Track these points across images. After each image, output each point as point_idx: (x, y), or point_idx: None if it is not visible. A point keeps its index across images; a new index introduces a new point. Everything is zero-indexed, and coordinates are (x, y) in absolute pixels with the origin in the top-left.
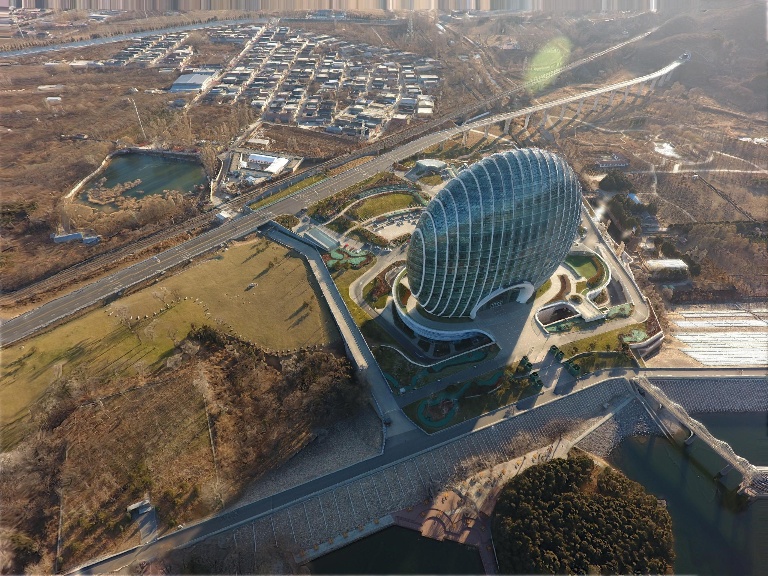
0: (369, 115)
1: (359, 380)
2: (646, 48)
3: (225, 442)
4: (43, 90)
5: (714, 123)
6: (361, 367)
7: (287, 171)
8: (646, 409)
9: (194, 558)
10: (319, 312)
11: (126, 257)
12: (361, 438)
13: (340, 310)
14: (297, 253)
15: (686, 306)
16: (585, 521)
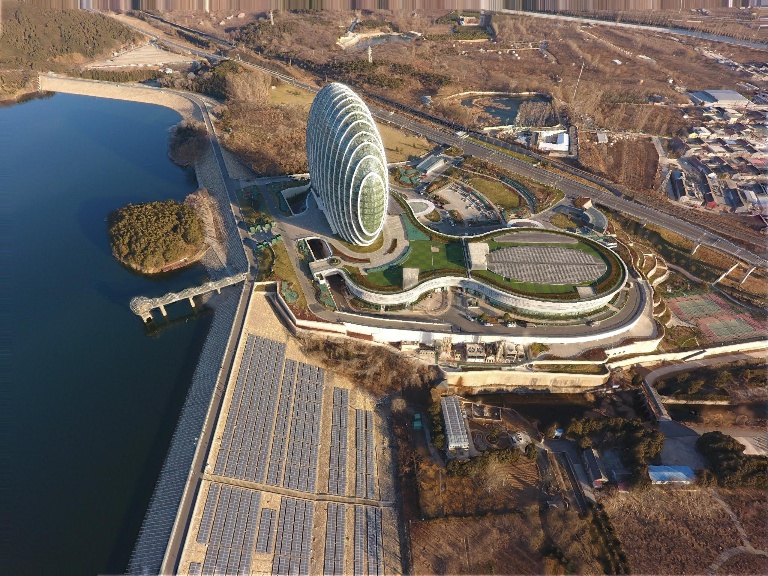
0: (747, 196)
1: None
2: None
3: None
4: (634, 57)
5: None
6: (293, 177)
7: (544, 151)
8: None
9: None
10: None
11: (409, 115)
12: None
13: None
14: None
15: (385, 431)
16: None
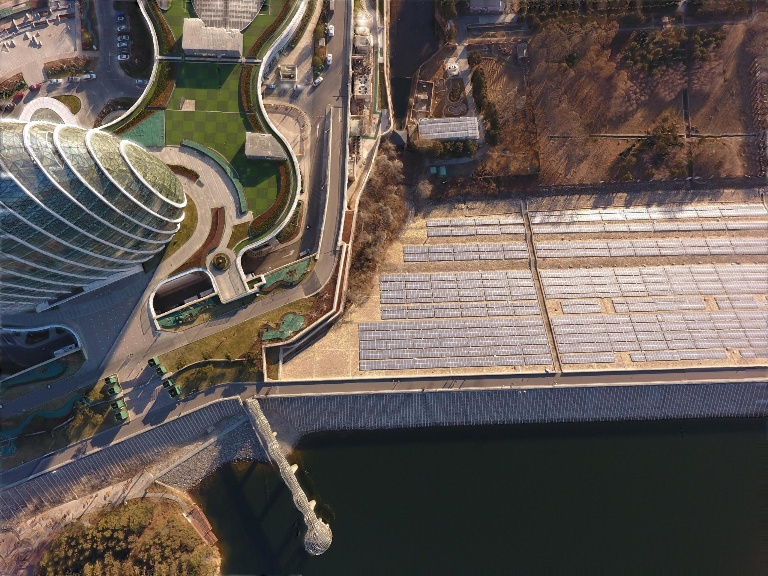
0: None
1: None
2: None
3: None
4: None
5: None
6: None
7: None
8: (256, 434)
9: None
10: None
11: None
12: None
13: None
14: None
15: (448, 207)
16: None
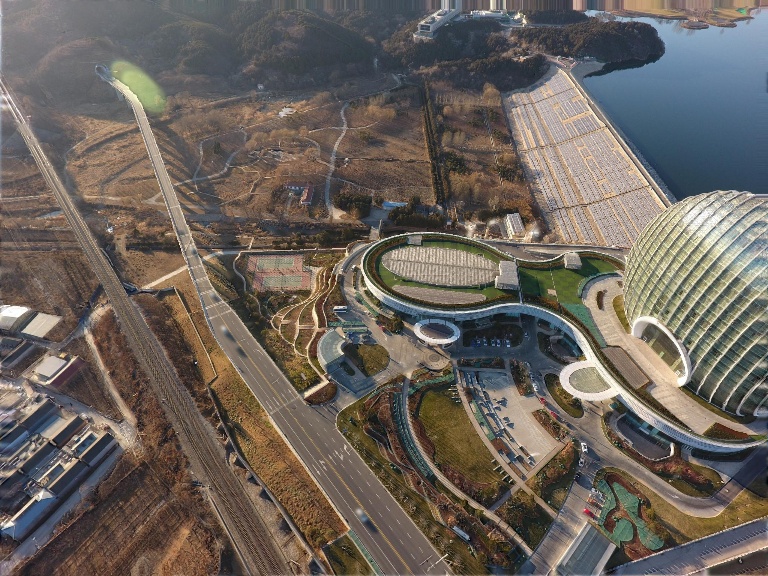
0: (6, 425)
1: None
2: (41, 77)
3: None
4: None
5: (243, 114)
6: None
7: None
8: None
9: None
10: None
11: None
12: None
13: (760, 533)
14: None
15: None
16: None
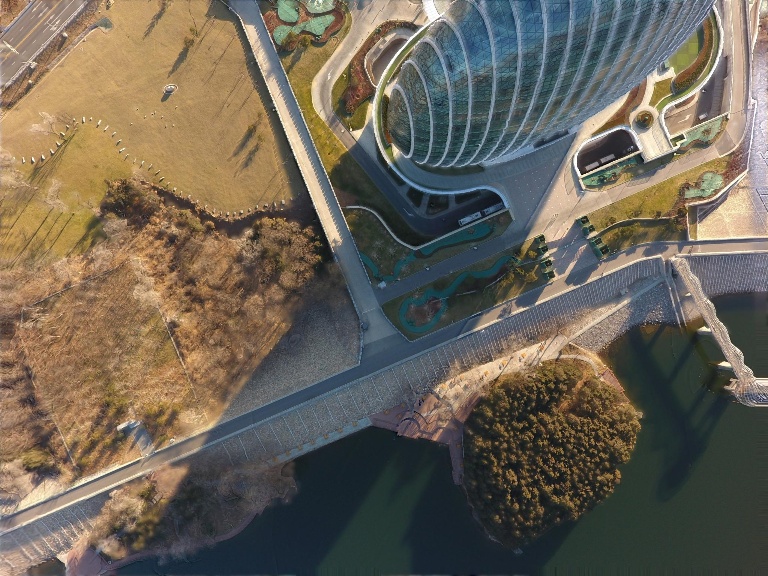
0: None
1: (330, 275)
2: None
3: (192, 350)
4: None
5: None
6: (333, 243)
7: None
8: (670, 295)
9: (191, 480)
10: (272, 142)
11: None
12: (337, 335)
13: (301, 138)
14: (224, 8)
15: None
16: (553, 446)
